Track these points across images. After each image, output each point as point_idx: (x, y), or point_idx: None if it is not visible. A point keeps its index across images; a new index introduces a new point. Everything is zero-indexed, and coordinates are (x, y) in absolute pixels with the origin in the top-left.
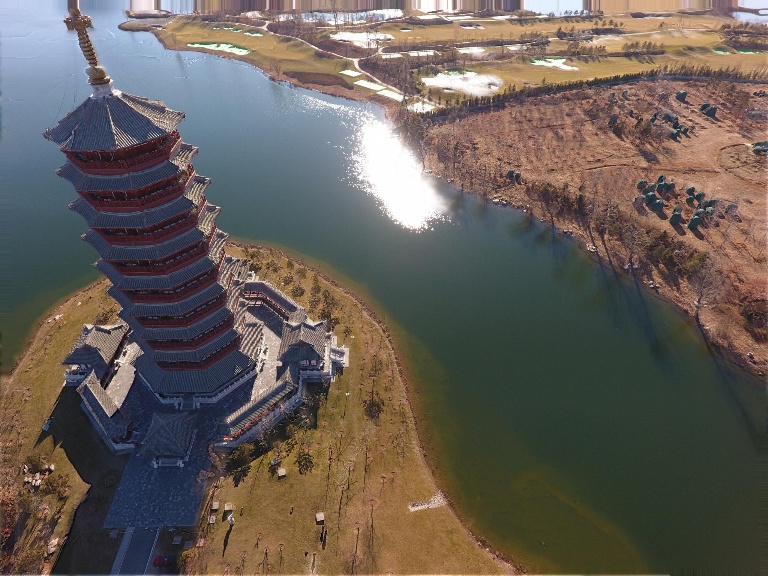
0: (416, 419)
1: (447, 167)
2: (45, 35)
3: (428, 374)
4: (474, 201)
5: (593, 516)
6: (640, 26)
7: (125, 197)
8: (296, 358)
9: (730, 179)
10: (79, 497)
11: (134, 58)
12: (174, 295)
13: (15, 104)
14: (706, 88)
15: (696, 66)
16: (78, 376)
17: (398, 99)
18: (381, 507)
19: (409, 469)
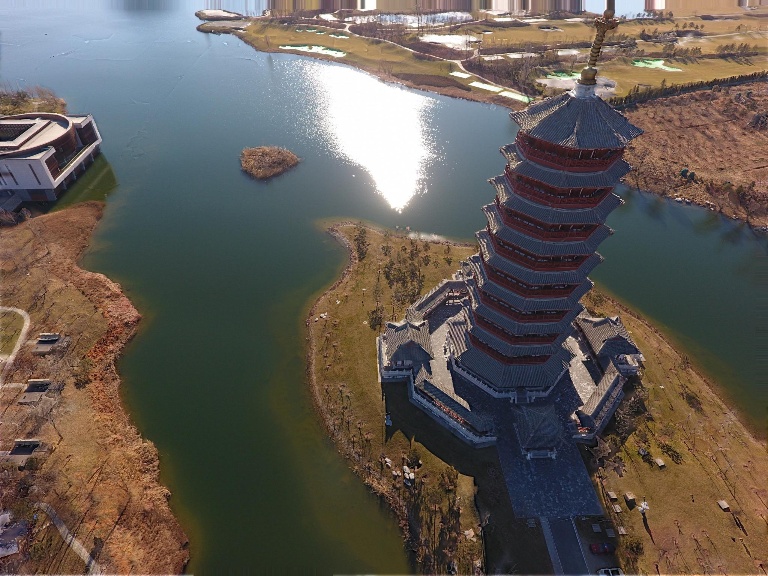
0: (733, 411)
1: None
2: (128, 37)
3: (713, 367)
4: (656, 200)
5: None
6: (716, 28)
7: (578, 194)
8: (614, 352)
9: None
10: (469, 489)
11: (234, 60)
12: (569, 290)
13: (143, 106)
14: None
15: None
16: (396, 372)
17: (524, 100)
18: (765, 495)
19: (760, 458)
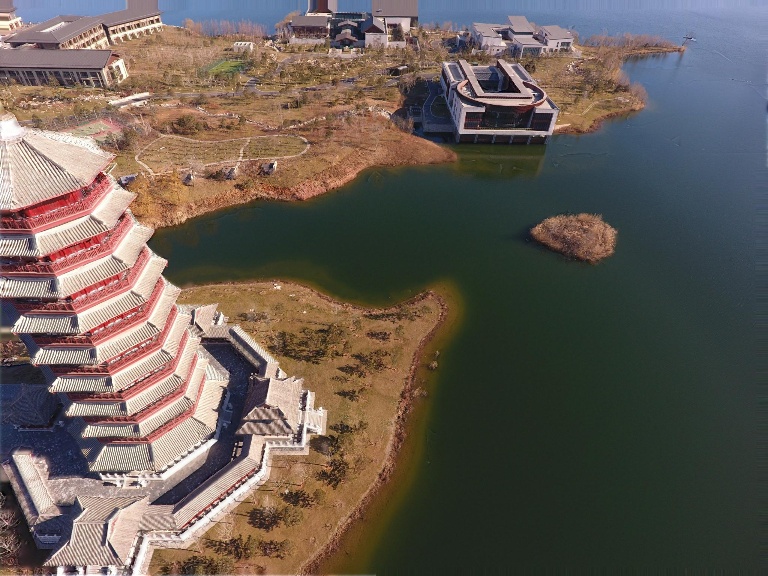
0: None
1: None
2: None
3: None
4: None
5: None
6: None
7: None
8: (68, 522)
9: None
10: None
11: None
12: None
13: (667, 144)
14: None
15: None
16: None
17: None
18: None
19: None
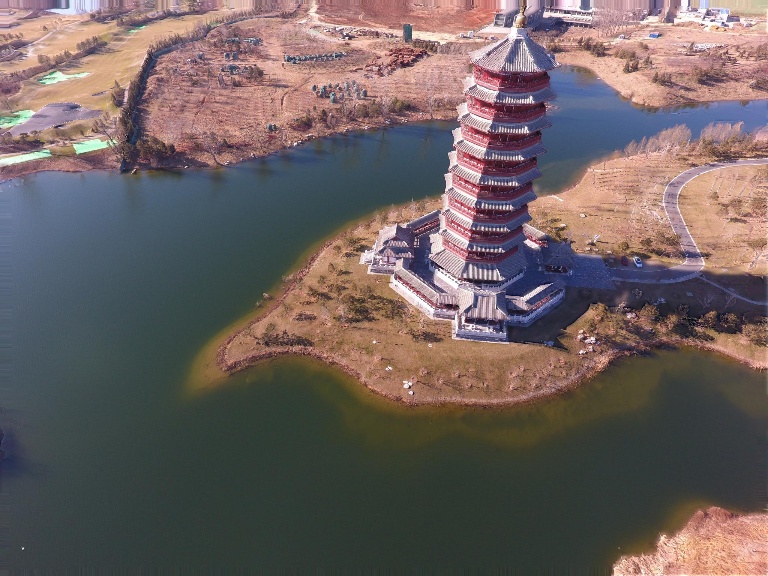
0: None
1: (232, 152)
2: None
3: None
4: (289, 153)
5: (547, 166)
6: None
7: None
8: None
9: (322, 76)
10: None
11: None
12: None
13: None
14: (197, 48)
15: (168, 38)
16: None
17: (43, 156)
18: None
19: None
